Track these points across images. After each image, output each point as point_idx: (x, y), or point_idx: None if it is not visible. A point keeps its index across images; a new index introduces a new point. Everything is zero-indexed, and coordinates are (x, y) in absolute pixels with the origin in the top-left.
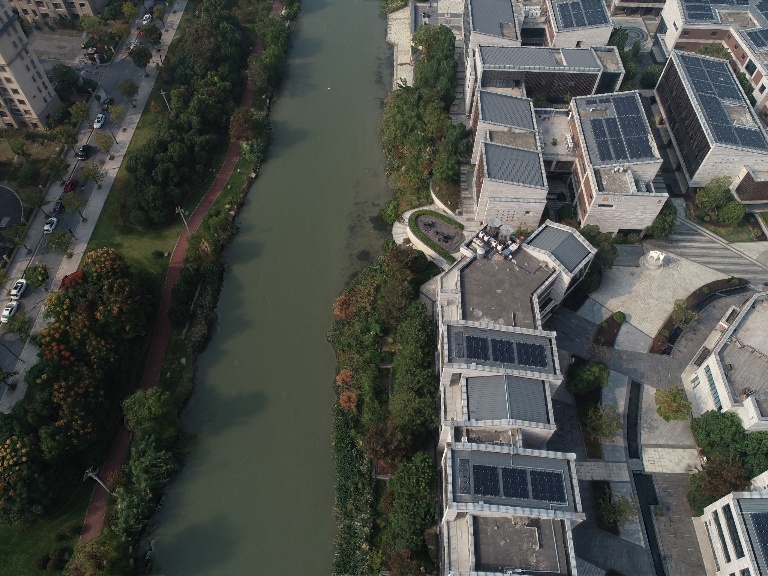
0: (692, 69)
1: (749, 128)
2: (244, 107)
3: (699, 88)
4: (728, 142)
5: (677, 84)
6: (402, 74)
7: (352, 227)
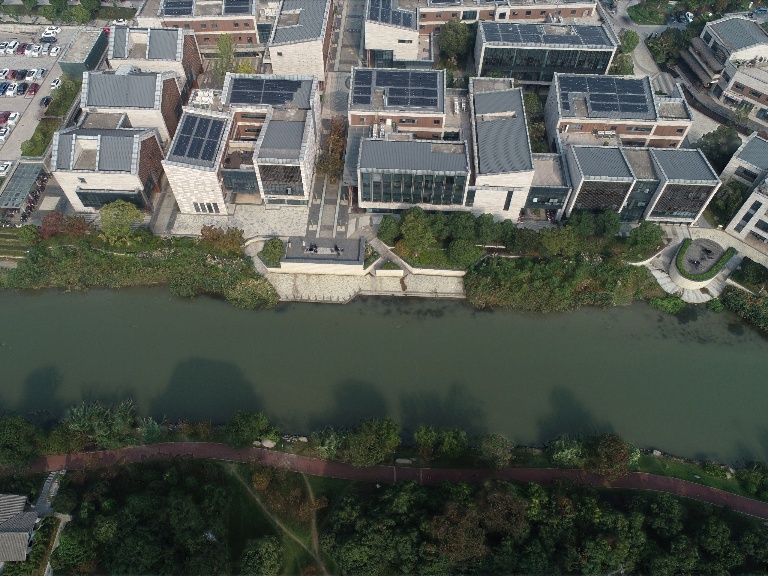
0: (506, 39)
1: (575, 29)
2: (602, 446)
3: (535, 40)
4: (604, 41)
5: (517, 54)
6: (425, 287)
7: (701, 340)
